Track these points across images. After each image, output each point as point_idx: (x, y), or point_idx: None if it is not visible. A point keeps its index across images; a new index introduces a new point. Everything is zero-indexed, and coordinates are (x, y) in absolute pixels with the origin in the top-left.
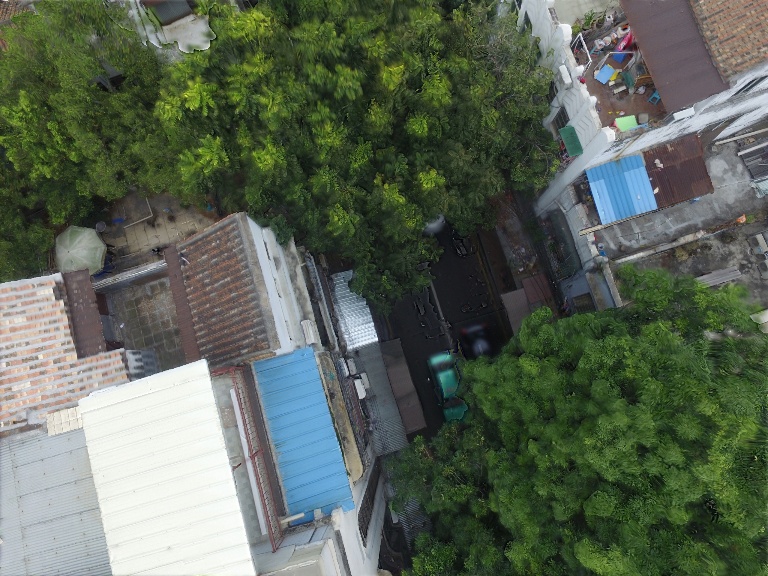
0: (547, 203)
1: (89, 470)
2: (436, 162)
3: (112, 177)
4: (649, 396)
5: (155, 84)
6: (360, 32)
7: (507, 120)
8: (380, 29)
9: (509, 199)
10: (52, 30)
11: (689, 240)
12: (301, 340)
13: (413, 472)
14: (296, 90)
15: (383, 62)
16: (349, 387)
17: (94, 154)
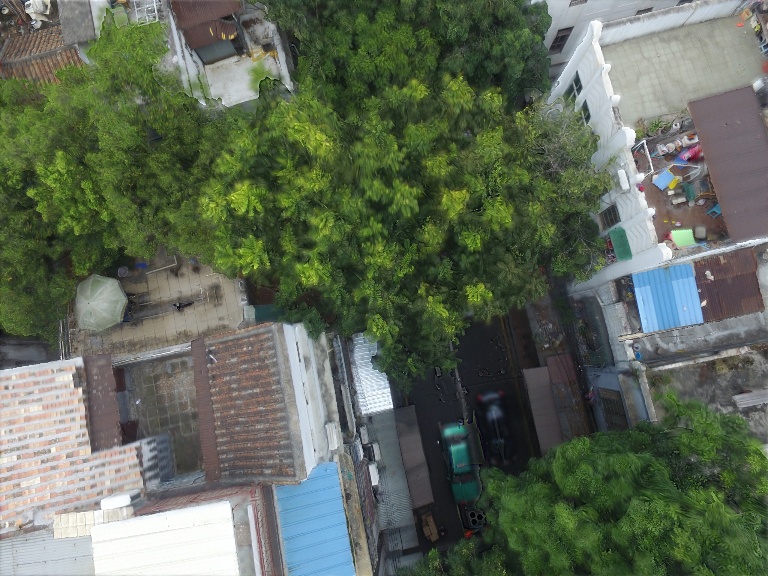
0: (583, 288)
1: None
2: (482, 266)
3: (142, 240)
4: None
5: (195, 142)
6: (420, 139)
7: (555, 213)
8: (442, 137)
9: (541, 271)
10: (97, 99)
11: (732, 355)
12: (325, 450)
13: None
14: (350, 208)
15: (443, 178)
16: (363, 473)
17: (126, 218)
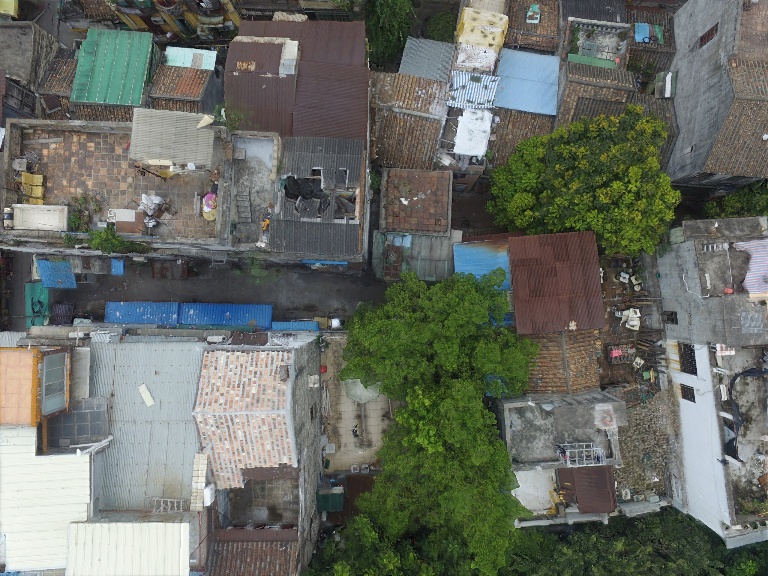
0: None
1: (169, 475)
2: None
3: None
4: None
5: None
6: None
7: None
8: None
9: None
10: None
11: None
12: None
13: None
14: None
15: None
16: None
17: None
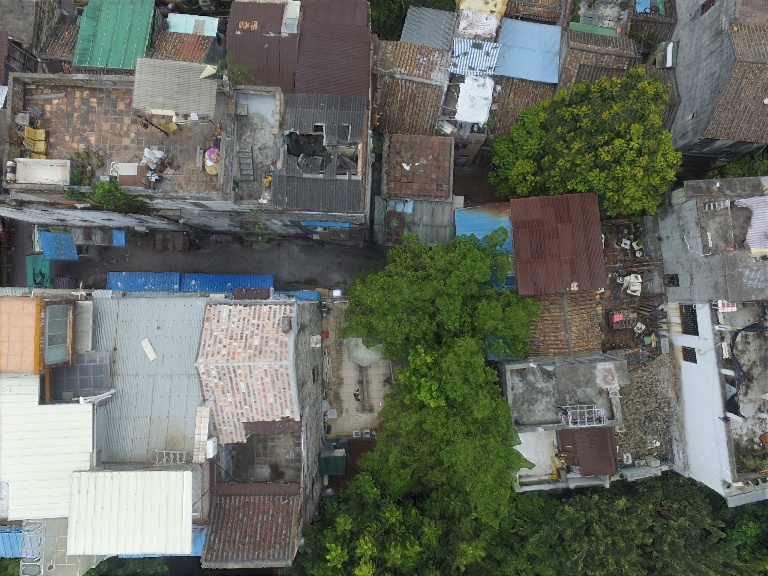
0: None
1: (172, 428)
2: None
3: None
4: None
5: None
6: None
7: None
8: None
9: None
10: None
11: None
12: None
13: (148, 558)
14: None
15: None
16: None
17: None
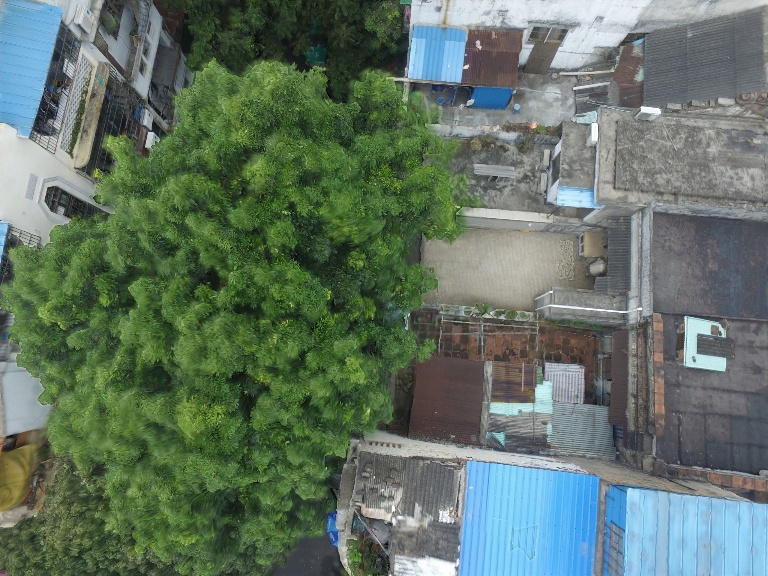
0: None
1: None
2: None
3: None
4: (250, 78)
5: None
6: None
7: None
8: None
9: None
10: None
11: (485, 130)
12: (63, 7)
13: None
14: None
15: None
16: (138, 131)
17: None
